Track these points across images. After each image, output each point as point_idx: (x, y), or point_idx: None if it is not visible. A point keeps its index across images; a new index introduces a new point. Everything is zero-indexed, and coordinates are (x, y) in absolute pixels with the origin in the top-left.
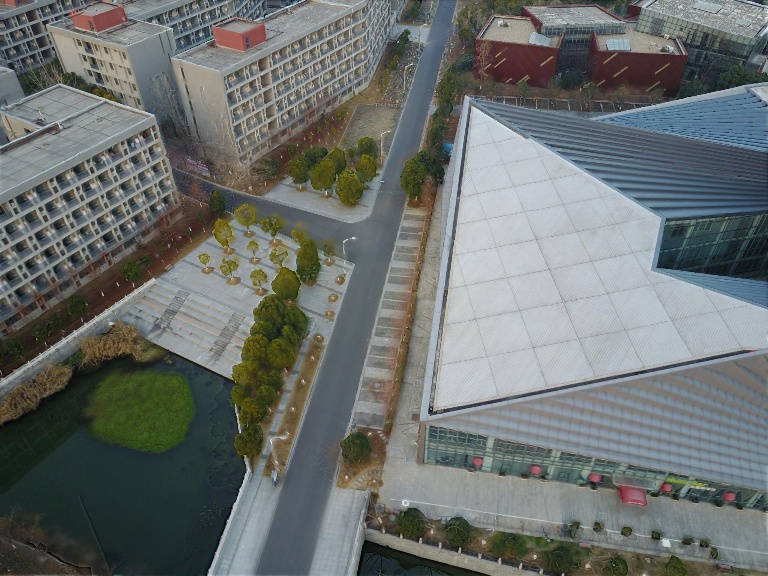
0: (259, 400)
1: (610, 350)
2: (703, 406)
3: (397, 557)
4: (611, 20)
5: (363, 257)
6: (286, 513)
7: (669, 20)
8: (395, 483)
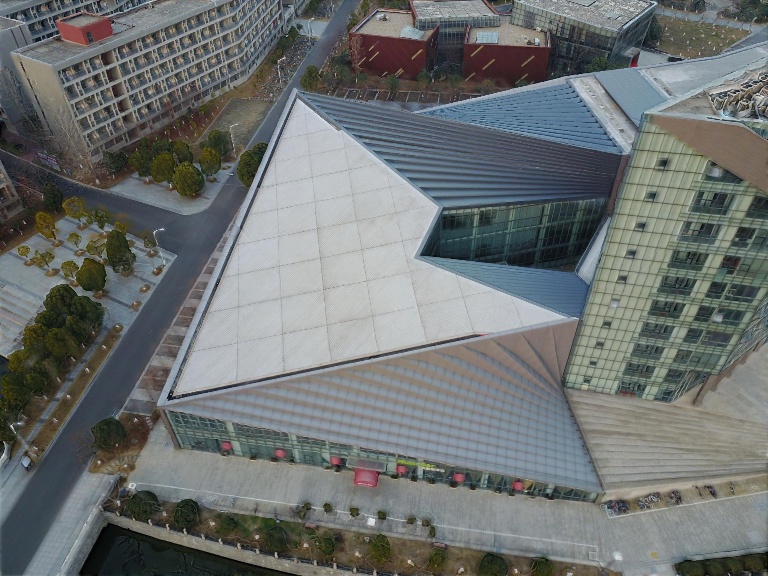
0: (23, 388)
1: (352, 336)
2: (438, 389)
3: (142, 539)
4: (487, 13)
5: (187, 248)
6: (30, 497)
7: (539, 13)
8: (147, 467)
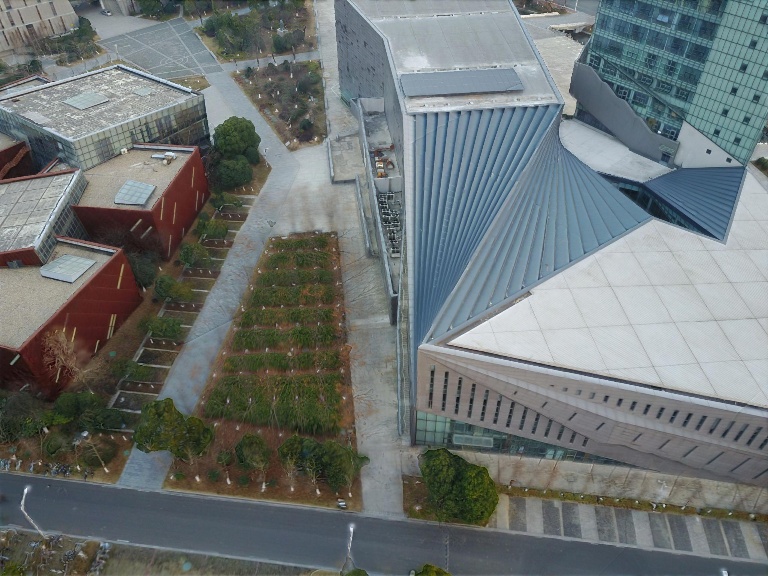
0: None
1: None
2: None
3: None
4: (54, 181)
5: None
6: None
7: (112, 133)
8: None
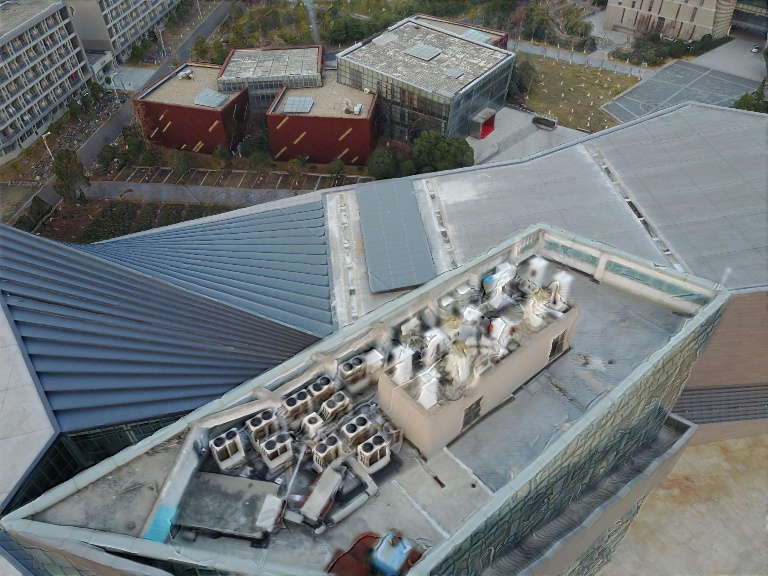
0: None
1: None
2: None
3: None
4: (308, 70)
5: None
6: None
7: (365, 71)
8: None
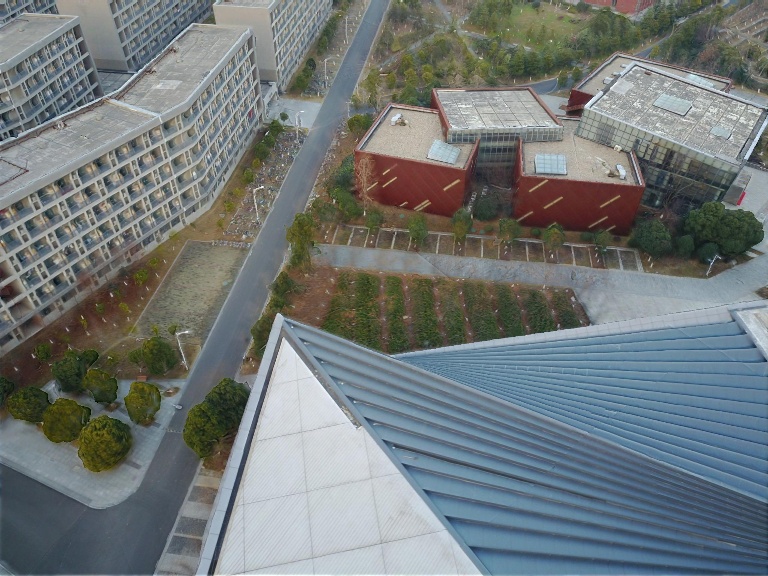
0: None
1: None
2: None
3: None
4: (544, 120)
5: None
6: None
7: (621, 127)
8: None
